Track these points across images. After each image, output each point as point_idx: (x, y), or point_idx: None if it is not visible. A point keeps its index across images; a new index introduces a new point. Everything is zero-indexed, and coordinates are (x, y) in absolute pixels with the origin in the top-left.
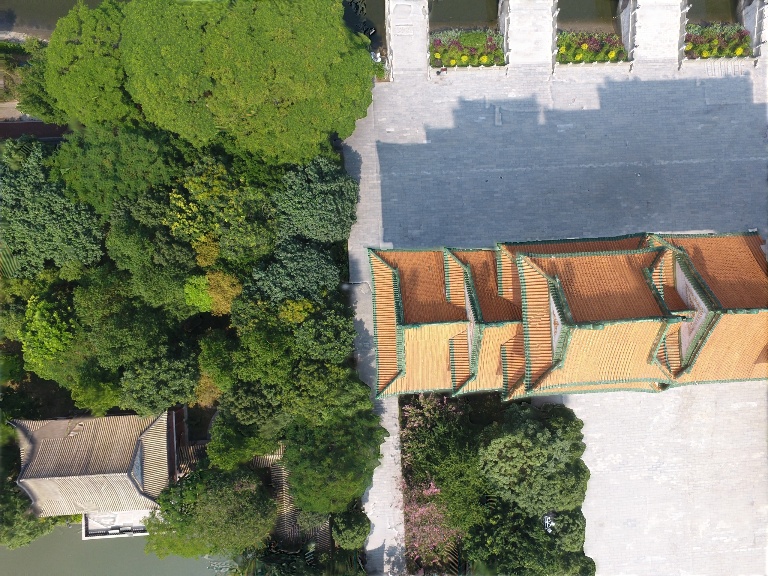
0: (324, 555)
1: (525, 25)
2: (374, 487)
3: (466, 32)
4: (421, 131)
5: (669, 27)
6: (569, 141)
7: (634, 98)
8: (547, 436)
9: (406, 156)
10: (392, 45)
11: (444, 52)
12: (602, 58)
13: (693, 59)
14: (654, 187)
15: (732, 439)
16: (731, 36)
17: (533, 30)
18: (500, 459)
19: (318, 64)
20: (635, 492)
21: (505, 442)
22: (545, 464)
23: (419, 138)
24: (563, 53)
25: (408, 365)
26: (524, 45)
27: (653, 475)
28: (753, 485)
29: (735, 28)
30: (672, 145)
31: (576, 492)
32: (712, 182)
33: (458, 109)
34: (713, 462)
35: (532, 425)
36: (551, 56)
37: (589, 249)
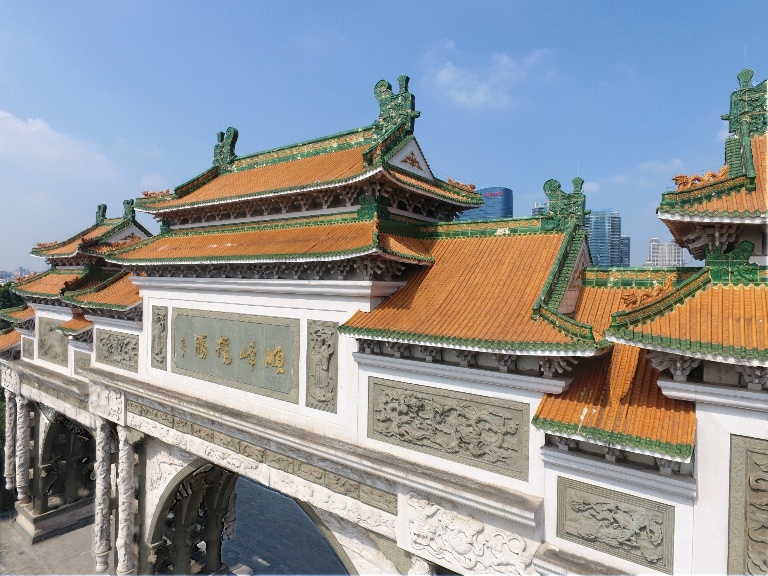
0: None
1: None
2: None
3: None
4: None
5: None
6: None
7: None
8: None
9: None
10: None
11: None
12: None
13: None
14: None
15: None
16: None
17: None
18: None
19: None
20: None
21: None
22: None
23: None
24: None
25: None
26: None
27: None
28: None
29: None
30: None
31: None
32: None
33: None
34: None
35: None
36: None
37: None
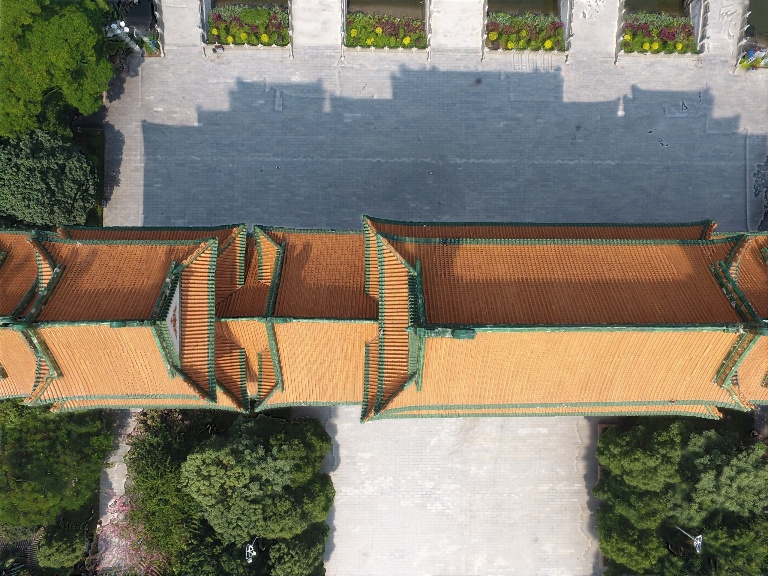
0: (23, 572)
1: (311, 3)
2: (114, 499)
3: (250, 8)
4: (192, 112)
5: (471, 14)
6: (356, 132)
7: (431, 89)
8: (260, 454)
9: (174, 139)
10: (163, 17)
11: (225, 28)
12: (398, 44)
13: (495, 50)
14: (447, 187)
15: (518, 467)
16: (543, 28)
17: (320, 9)
18: (197, 477)
19: (0, 23)
20: (405, 520)
21: (204, 458)
22: (248, 485)
23: (190, 120)
24: (355, 36)
25: (6, 364)
26: (310, 25)
27: (427, 502)
28: (538, 519)
29: (548, 19)
30: (470, 142)
31: (288, 519)
32: (512, 185)
33: (235, 91)
34: (495, 492)
35: (245, 441)
36: (340, 39)
37: (173, 239)
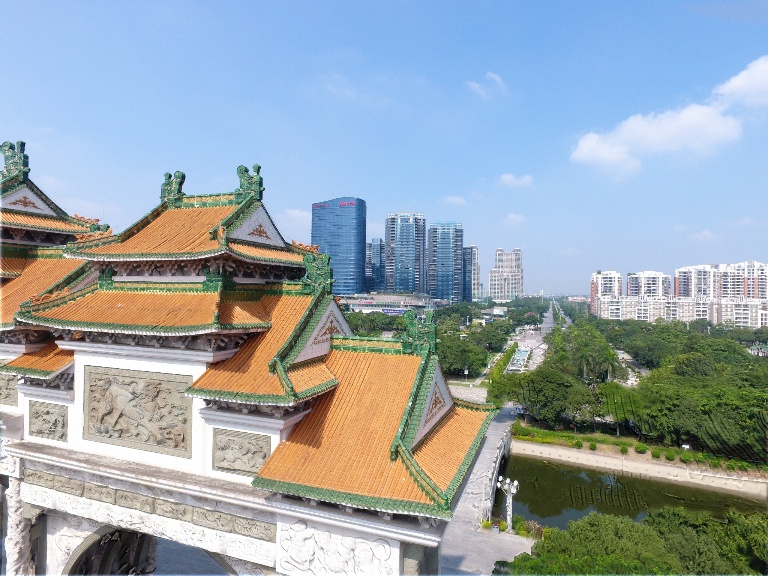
0: None
1: None
2: None
3: None
4: None
5: None
6: None
7: None
8: None
9: None
10: None
11: None
12: None
13: None
14: None
15: None
16: None
17: None
18: None
19: None
20: None
21: None
22: None
23: None
24: None
25: None
26: None
27: None
28: None
29: None
30: None
31: None
32: (174, 547)
33: None
34: None
35: None
36: None
37: None
